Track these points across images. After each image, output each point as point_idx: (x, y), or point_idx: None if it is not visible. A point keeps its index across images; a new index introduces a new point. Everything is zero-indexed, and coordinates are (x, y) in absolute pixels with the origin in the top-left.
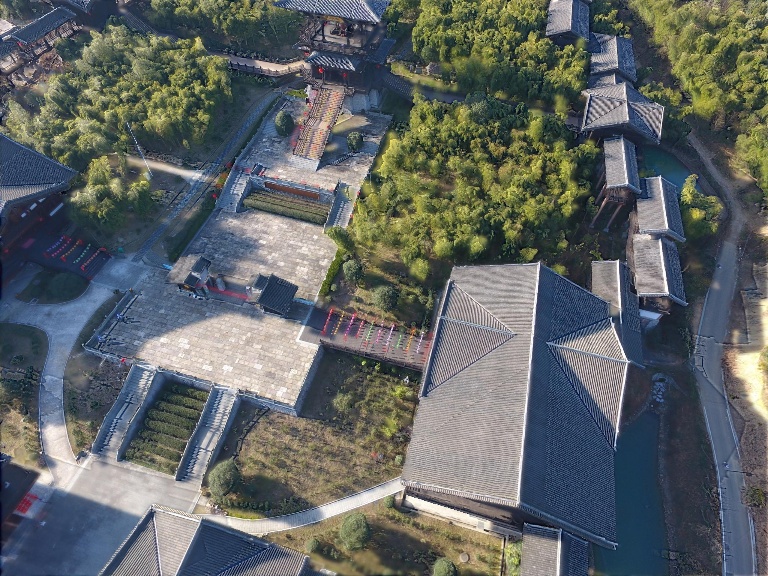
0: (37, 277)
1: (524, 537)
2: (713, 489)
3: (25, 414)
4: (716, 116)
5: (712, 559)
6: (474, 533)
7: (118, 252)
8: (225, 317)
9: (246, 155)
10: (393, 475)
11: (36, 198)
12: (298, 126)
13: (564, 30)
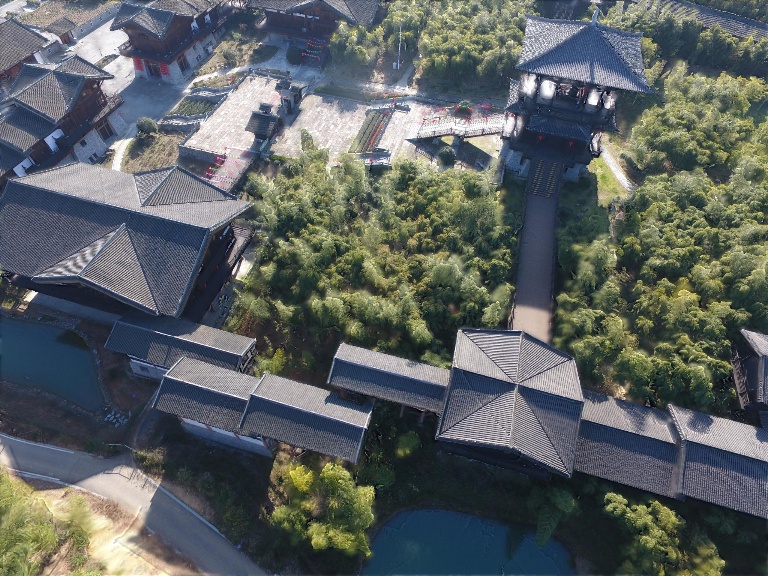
0: None
1: None
2: None
3: (218, 66)
4: None
5: None
6: None
7: None
8: None
9: (423, 102)
10: None
11: (334, 12)
12: None
13: (758, 348)
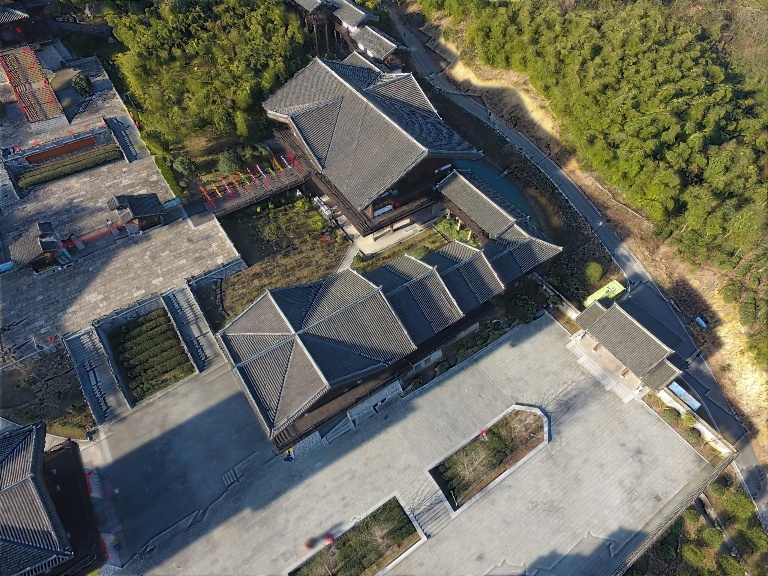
0: None
1: (442, 191)
2: (495, 132)
3: None
4: None
5: (520, 156)
6: (416, 237)
7: None
8: (111, 259)
9: None
10: (345, 250)
11: None
12: (6, 104)
13: None
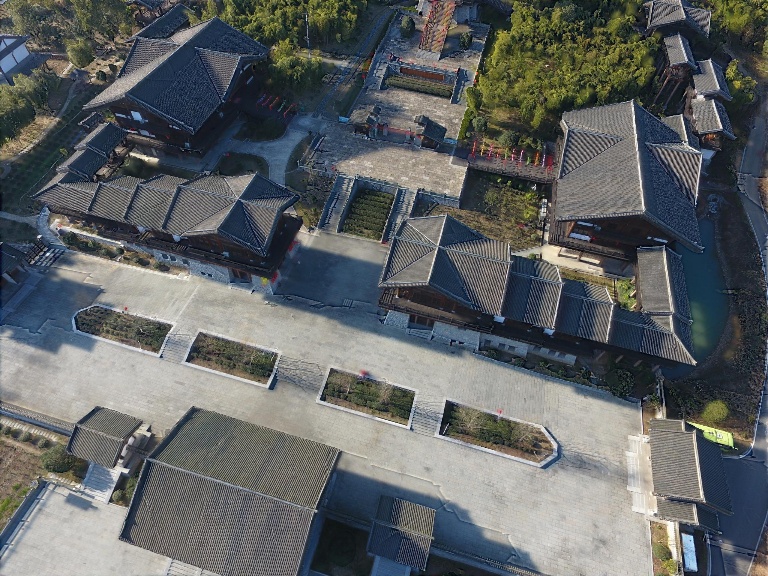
0: (244, 126)
1: (639, 254)
2: (757, 255)
3: None
4: (747, 29)
5: (759, 288)
6: (593, 277)
7: (300, 111)
8: (393, 150)
9: (381, 50)
10: (531, 246)
11: (253, 60)
12: (417, 31)
13: None
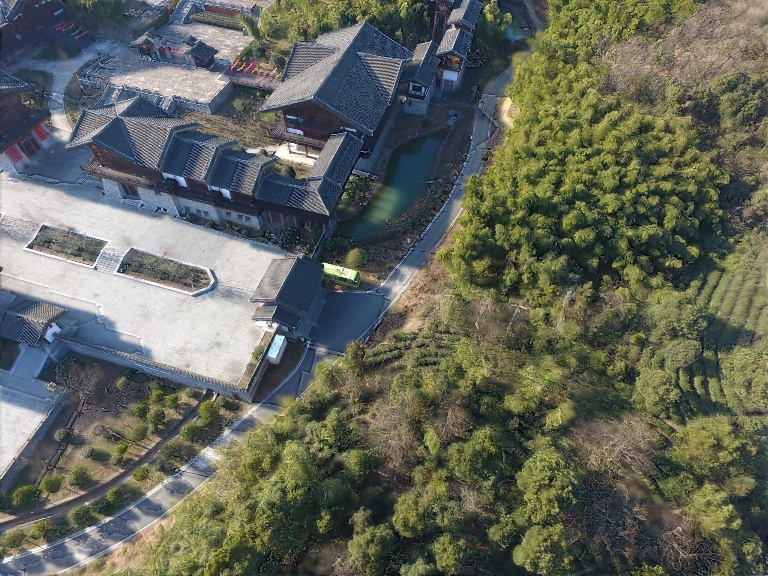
0: (46, 49)
1: (328, 140)
2: (464, 154)
3: None
4: None
5: (450, 176)
6: None
7: (100, 39)
8: (170, 69)
9: None
10: (269, 145)
11: None
12: None
13: None
